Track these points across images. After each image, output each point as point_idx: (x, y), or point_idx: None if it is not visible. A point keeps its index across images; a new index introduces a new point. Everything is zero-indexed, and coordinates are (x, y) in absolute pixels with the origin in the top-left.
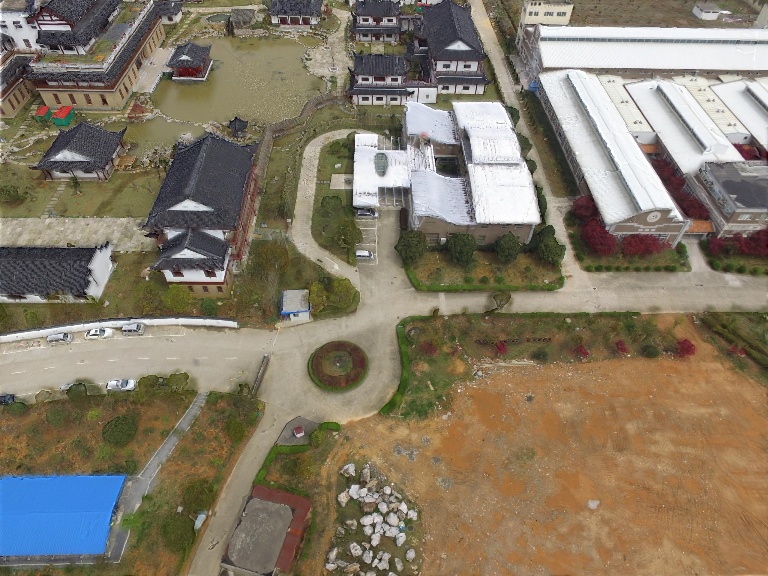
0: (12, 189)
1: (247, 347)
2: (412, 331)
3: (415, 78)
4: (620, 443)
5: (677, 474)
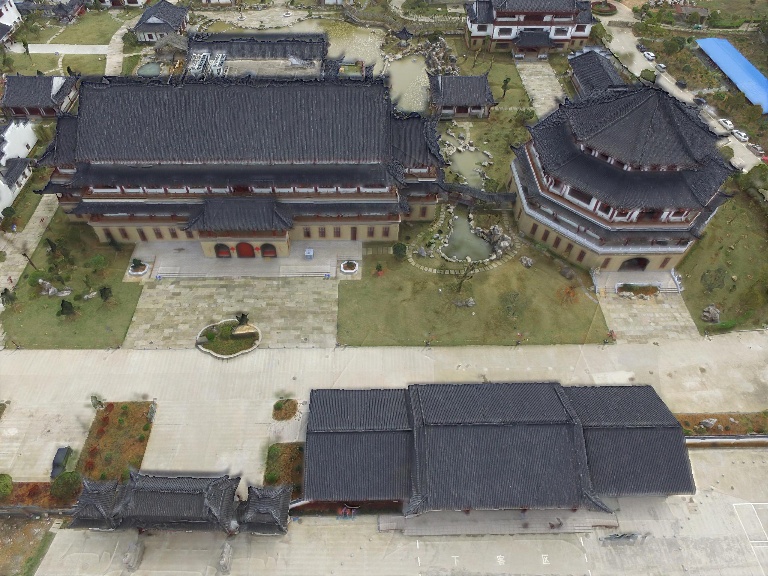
0: (522, 112)
1: None
2: None
3: None
4: None
5: None
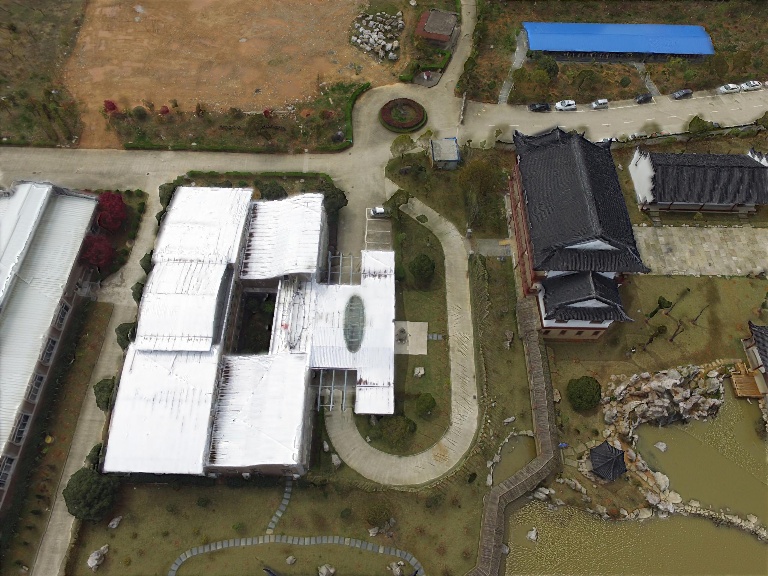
0: None
1: (480, 132)
2: (340, 134)
3: None
4: (207, 65)
5: (180, 49)
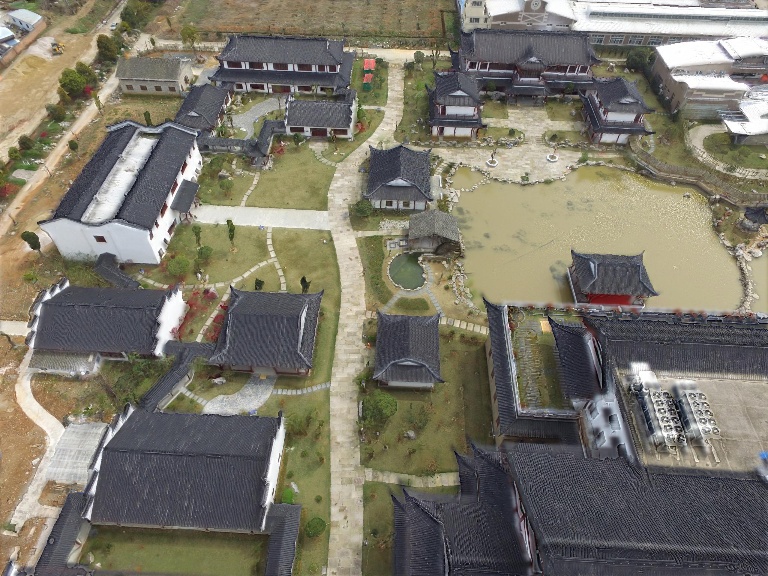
0: None
1: None
2: None
3: (569, 101)
4: None
5: None
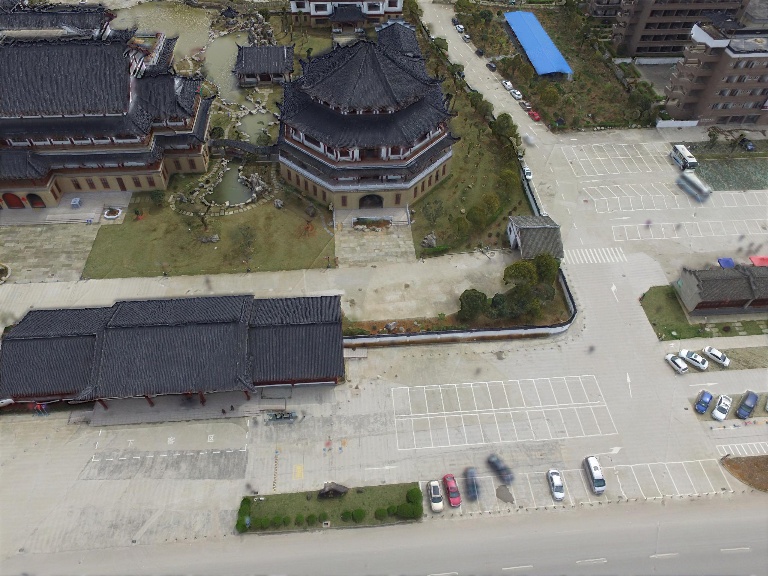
0: None
1: (428, 7)
2: None
3: None
4: None
5: None
